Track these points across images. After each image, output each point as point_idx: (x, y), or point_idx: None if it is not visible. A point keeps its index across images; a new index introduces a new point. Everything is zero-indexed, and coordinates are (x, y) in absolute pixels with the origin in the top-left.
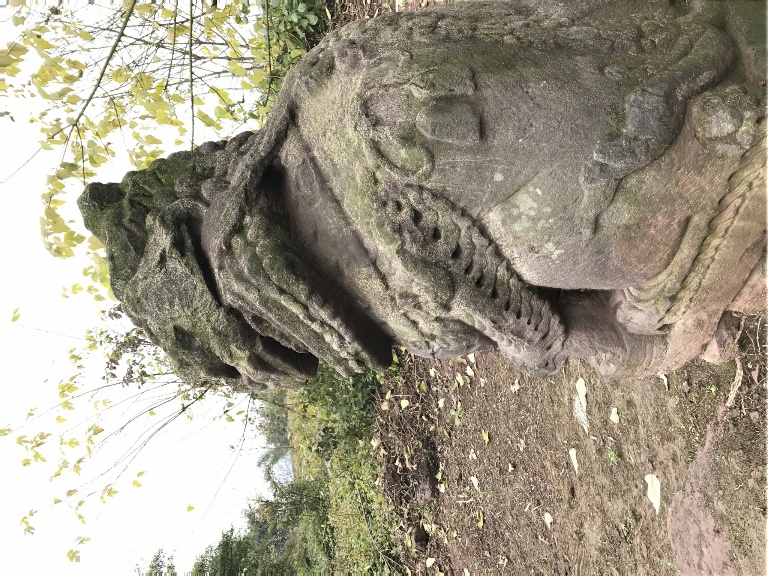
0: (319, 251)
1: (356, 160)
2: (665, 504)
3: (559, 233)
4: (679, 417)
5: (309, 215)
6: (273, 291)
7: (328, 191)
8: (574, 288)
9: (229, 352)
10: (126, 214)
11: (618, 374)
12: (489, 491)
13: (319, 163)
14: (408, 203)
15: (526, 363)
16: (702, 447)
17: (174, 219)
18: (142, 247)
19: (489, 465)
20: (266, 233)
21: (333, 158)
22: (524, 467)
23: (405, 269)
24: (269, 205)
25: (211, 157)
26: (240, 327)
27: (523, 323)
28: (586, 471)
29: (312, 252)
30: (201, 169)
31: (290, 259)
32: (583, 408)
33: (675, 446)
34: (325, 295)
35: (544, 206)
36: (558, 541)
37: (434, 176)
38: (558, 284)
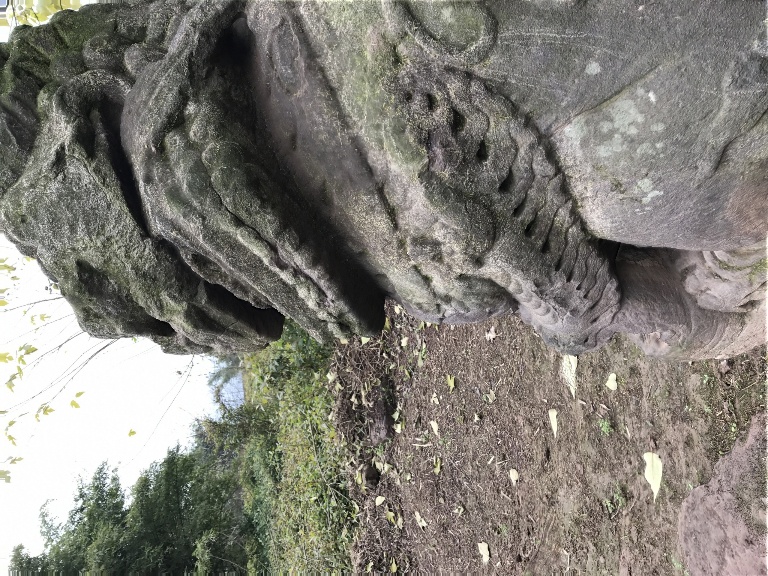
0: (297, 165)
1: (368, 23)
2: (667, 488)
3: (665, 165)
4: (703, 397)
5: (286, 109)
6: (225, 221)
7: (318, 72)
8: None
9: (158, 302)
10: (6, 86)
11: (670, 356)
12: (450, 438)
13: (307, 26)
14: (446, 99)
15: (558, 336)
16: (742, 442)
17: (80, 100)
18: (30, 139)
19: (452, 412)
20: (219, 131)
21: (330, 19)
22: (492, 419)
23: (428, 202)
24: (225, 89)
25: (142, 11)
26: (175, 268)
27: (571, 288)
28: (567, 436)
29: (287, 166)
30: (126, 28)
31: (254, 174)
32: (572, 368)
33: (692, 429)
34: (303, 232)
35: (655, 121)
36: (523, 500)
37: (493, 57)
38: (634, 239)
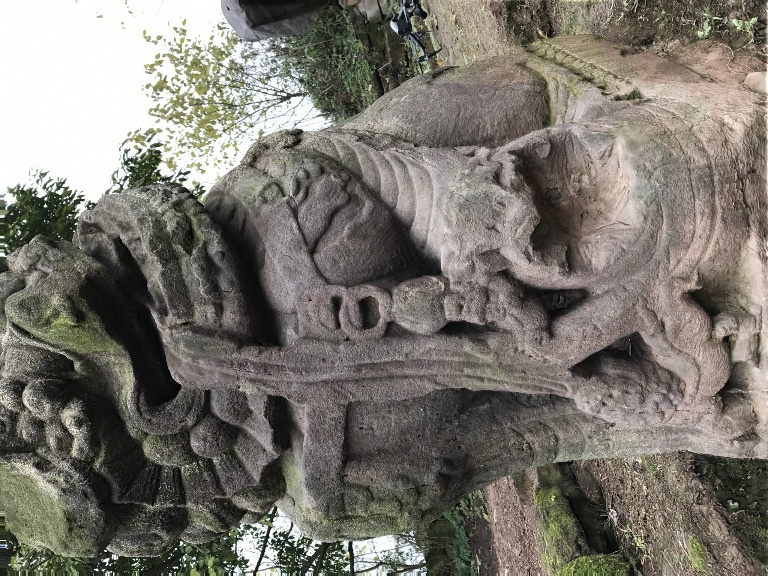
0: None
1: None
2: None
3: None
4: None
5: None
6: None
7: None
8: (458, 123)
9: None
10: None
11: (636, 139)
12: None
13: None
14: None
15: (453, 188)
16: None
17: None
18: None
19: None
20: None
21: None
22: None
23: None
24: None
25: None
26: None
27: None
28: None
29: None
30: None
31: None
32: None
33: None
34: None
35: None
36: None
37: None
38: (430, 120)
